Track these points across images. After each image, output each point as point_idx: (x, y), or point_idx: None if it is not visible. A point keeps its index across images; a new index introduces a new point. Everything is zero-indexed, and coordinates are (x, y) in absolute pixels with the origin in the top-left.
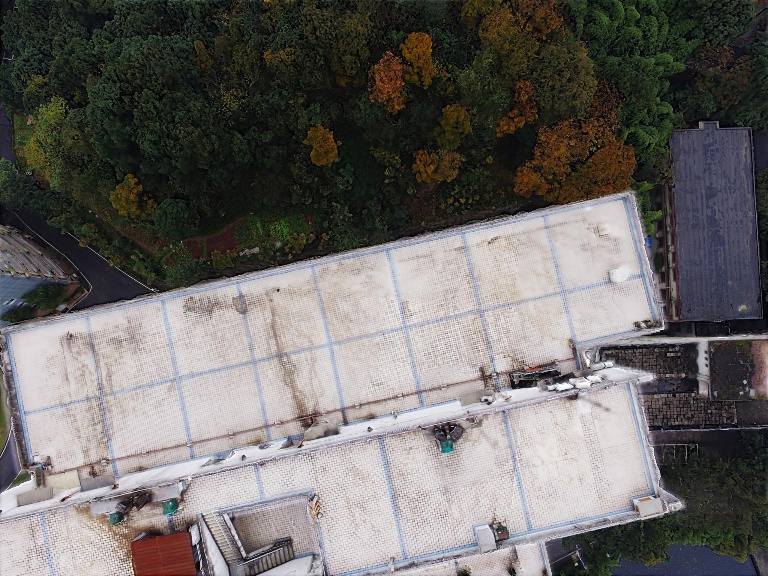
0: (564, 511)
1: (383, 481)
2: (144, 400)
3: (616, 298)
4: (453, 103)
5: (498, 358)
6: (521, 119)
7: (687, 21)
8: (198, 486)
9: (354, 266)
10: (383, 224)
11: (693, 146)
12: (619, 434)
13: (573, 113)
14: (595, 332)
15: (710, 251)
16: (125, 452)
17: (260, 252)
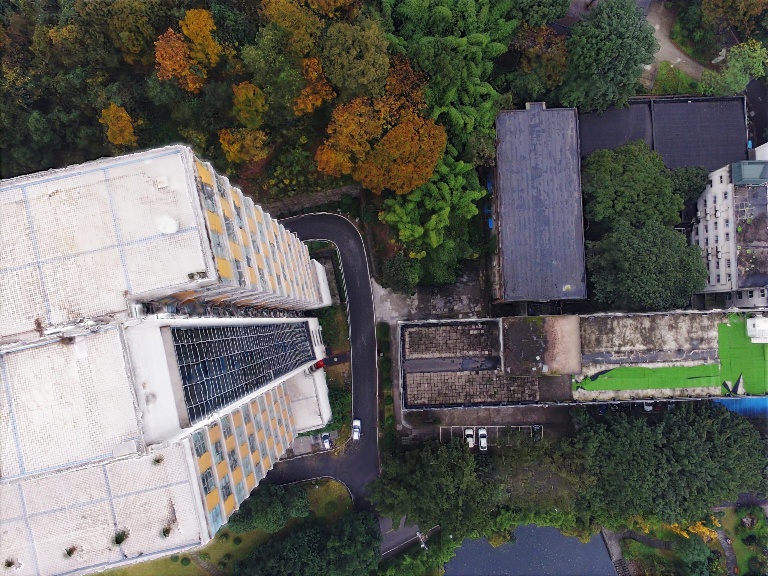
0: (56, 454)
1: None
2: None
3: (172, 250)
4: None
5: (54, 310)
6: (316, 97)
7: (505, 1)
8: None
9: None
10: None
11: (519, 127)
12: (114, 378)
13: (368, 91)
14: (150, 284)
15: (535, 231)
16: None
17: None
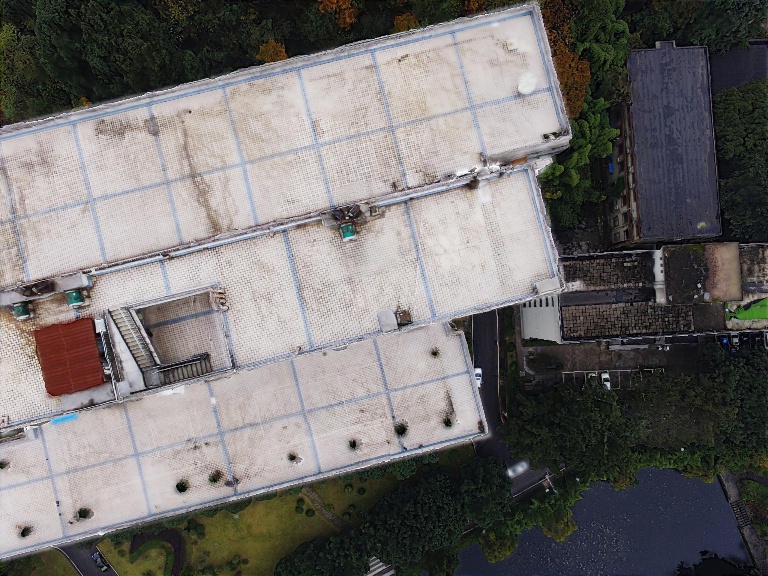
0: (467, 297)
1: (288, 273)
2: (58, 223)
3: (525, 111)
4: None
5: (410, 173)
6: None
7: None
8: (104, 283)
9: (265, 86)
10: None
11: (650, 66)
12: (519, 221)
13: None
14: (505, 145)
15: (669, 169)
16: (41, 274)
17: None
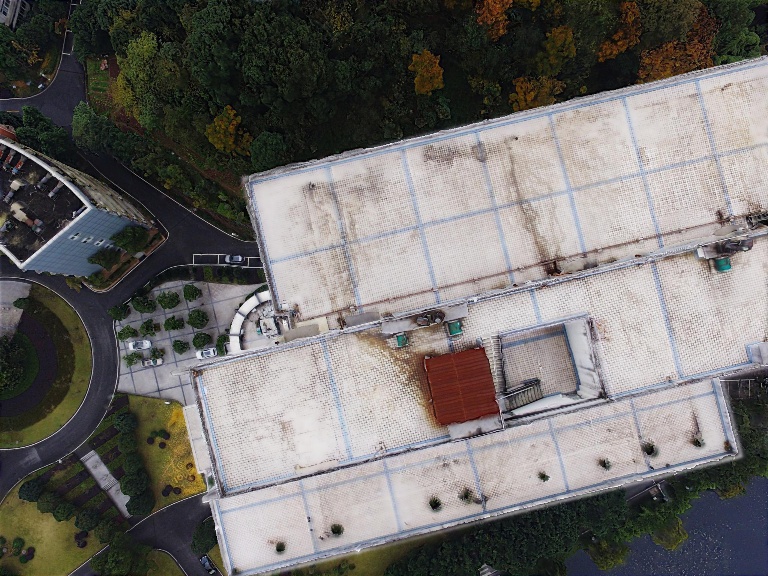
0: None
1: (656, 304)
2: (388, 248)
3: None
4: None
5: (734, 202)
6: (625, 43)
7: None
8: (476, 312)
9: (591, 114)
10: None
11: None
12: None
13: (676, 36)
14: None
15: None
16: (372, 299)
17: None
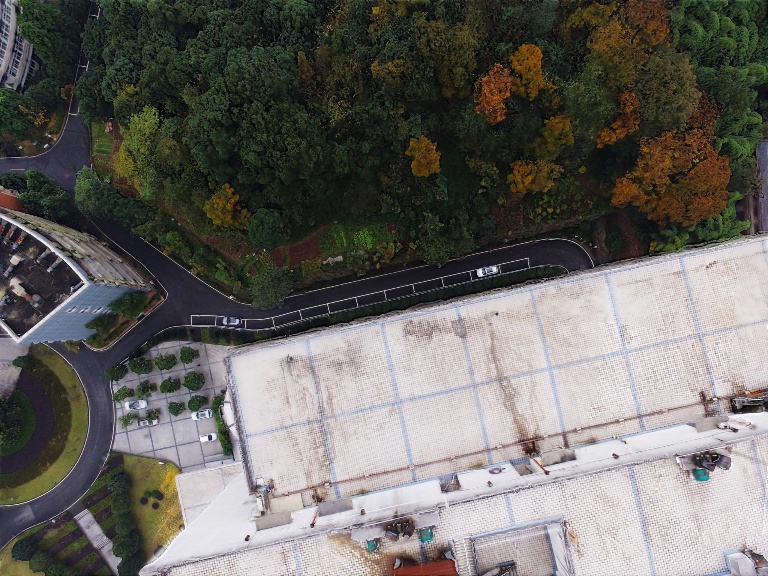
0: None
1: (633, 508)
2: (365, 423)
3: None
4: (552, 114)
5: (718, 383)
6: (623, 130)
7: None
8: (448, 512)
9: (573, 290)
10: (469, 233)
11: None
12: None
13: (675, 124)
14: None
15: None
16: (347, 475)
17: (349, 261)
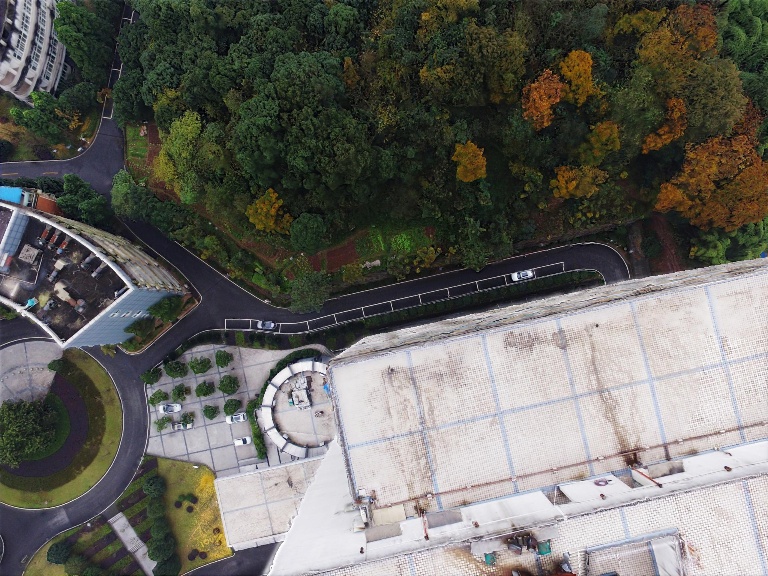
0: None
1: (748, 521)
2: (466, 435)
3: None
4: (596, 119)
5: None
6: (669, 136)
7: None
8: (563, 525)
9: (673, 302)
10: (509, 238)
11: None
12: None
13: (721, 130)
14: None
15: None
16: (449, 486)
17: (390, 266)
